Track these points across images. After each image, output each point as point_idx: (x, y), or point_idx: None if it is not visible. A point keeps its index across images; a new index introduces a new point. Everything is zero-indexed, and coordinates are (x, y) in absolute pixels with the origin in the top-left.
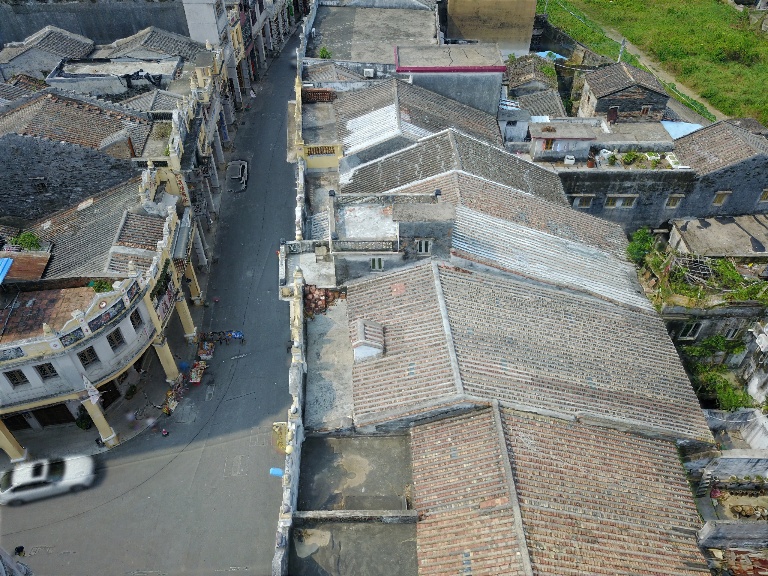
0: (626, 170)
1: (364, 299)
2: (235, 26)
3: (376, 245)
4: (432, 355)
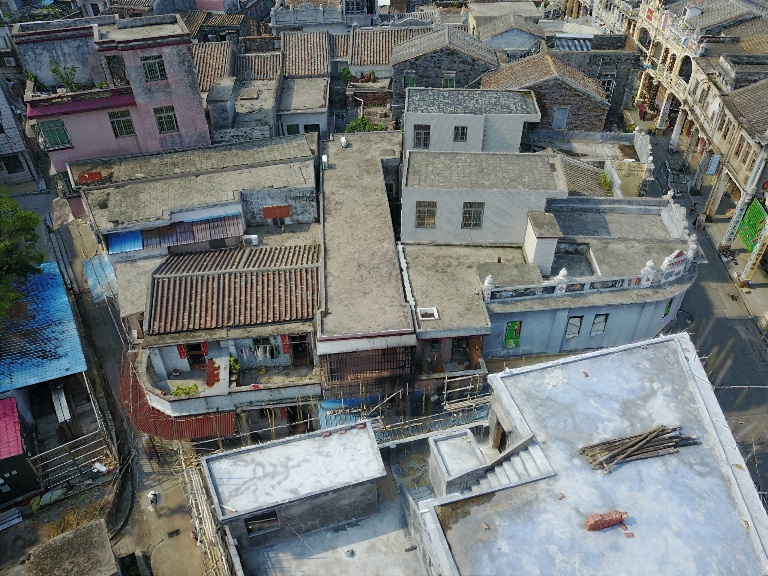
0: None
1: (680, 7)
2: None
3: None
4: (728, 8)
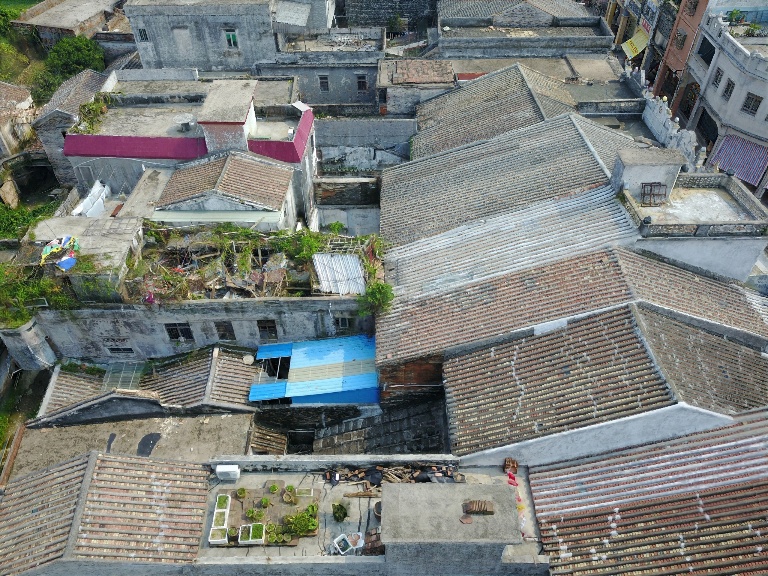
0: (335, 457)
1: None
2: None
3: (685, 181)
4: None
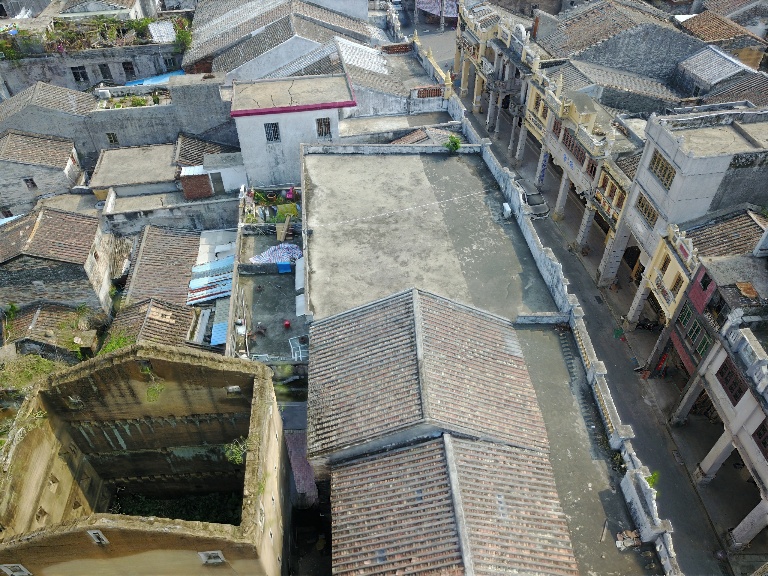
0: (154, 84)
1: None
2: (678, 260)
3: None
4: None
